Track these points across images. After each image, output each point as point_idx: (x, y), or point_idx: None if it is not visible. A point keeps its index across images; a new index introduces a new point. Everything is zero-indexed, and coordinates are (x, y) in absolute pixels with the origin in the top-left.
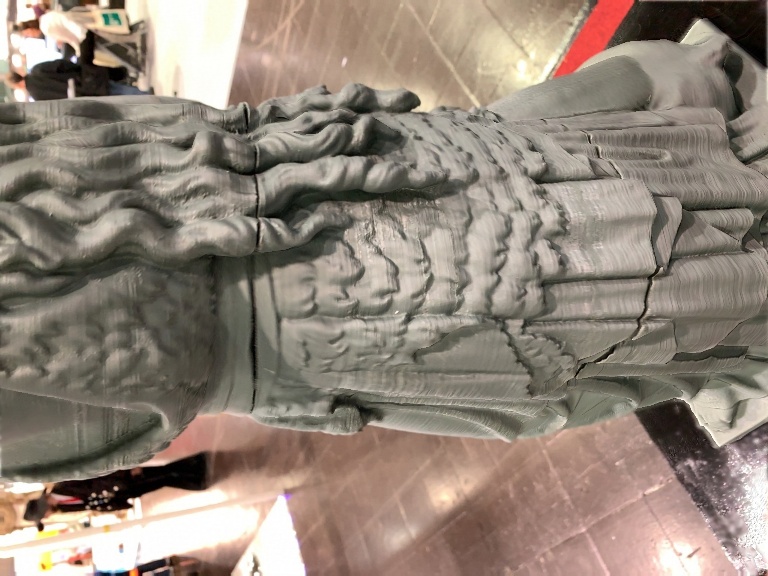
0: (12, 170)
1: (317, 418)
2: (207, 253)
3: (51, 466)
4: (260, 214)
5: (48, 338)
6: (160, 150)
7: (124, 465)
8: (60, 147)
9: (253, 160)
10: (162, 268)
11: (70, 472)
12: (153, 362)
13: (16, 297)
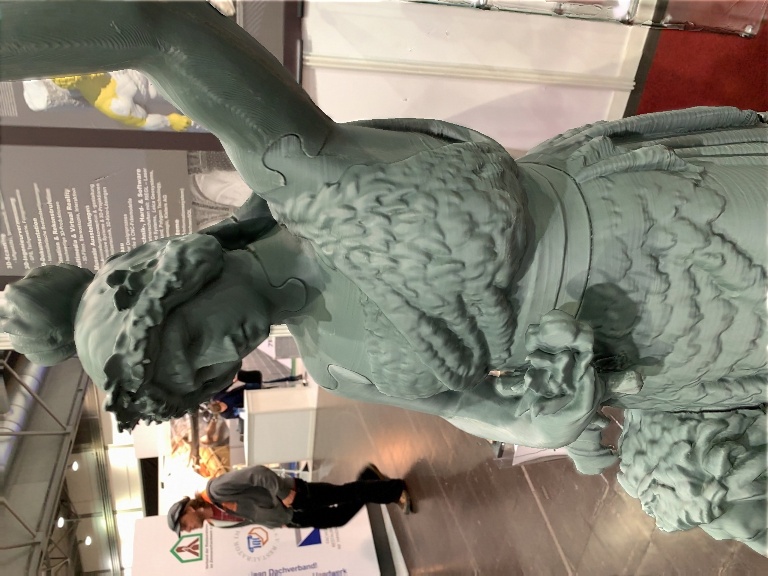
0: None
1: None
2: None
3: None
4: None
5: None
6: None
7: (477, 145)
8: None
9: None
10: None
11: None
12: None
13: None
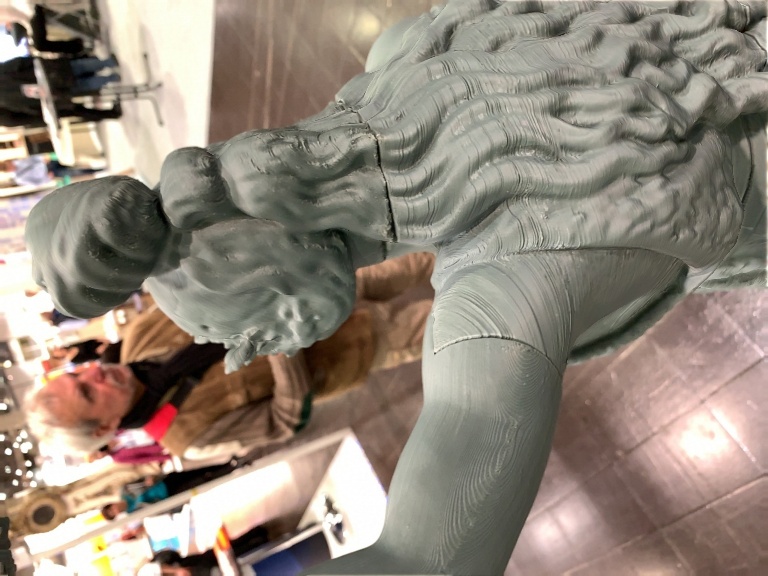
0: (616, 48)
1: (749, 274)
2: (743, 111)
3: (585, 346)
4: (766, 69)
5: (696, 200)
6: (673, 19)
7: None
8: (617, 24)
9: (745, 17)
10: (719, 130)
11: (603, 349)
12: (739, 218)
13: (669, 165)
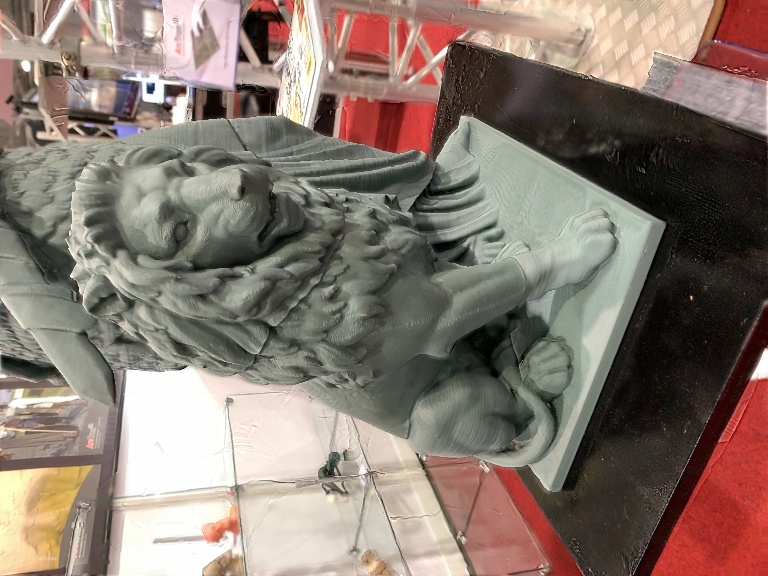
0: None
1: None
2: None
3: None
4: None
5: None
6: None
7: None
8: None
9: None
10: None
11: None
12: None
13: None
